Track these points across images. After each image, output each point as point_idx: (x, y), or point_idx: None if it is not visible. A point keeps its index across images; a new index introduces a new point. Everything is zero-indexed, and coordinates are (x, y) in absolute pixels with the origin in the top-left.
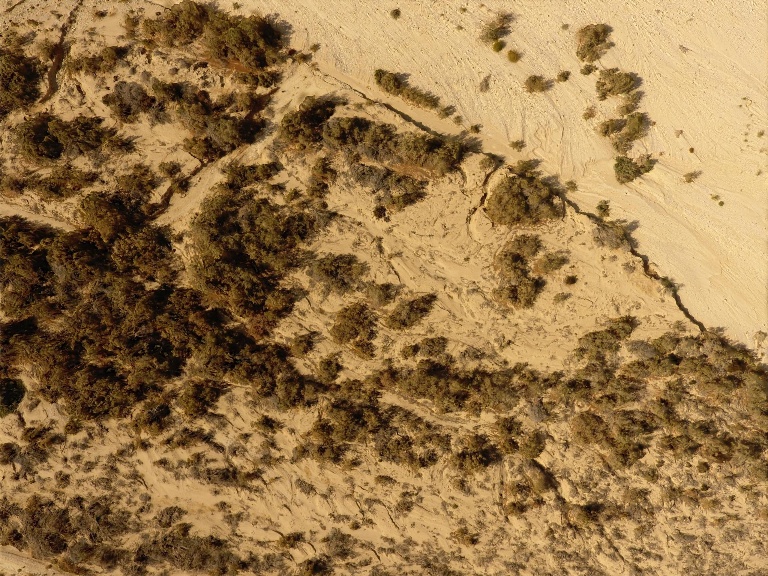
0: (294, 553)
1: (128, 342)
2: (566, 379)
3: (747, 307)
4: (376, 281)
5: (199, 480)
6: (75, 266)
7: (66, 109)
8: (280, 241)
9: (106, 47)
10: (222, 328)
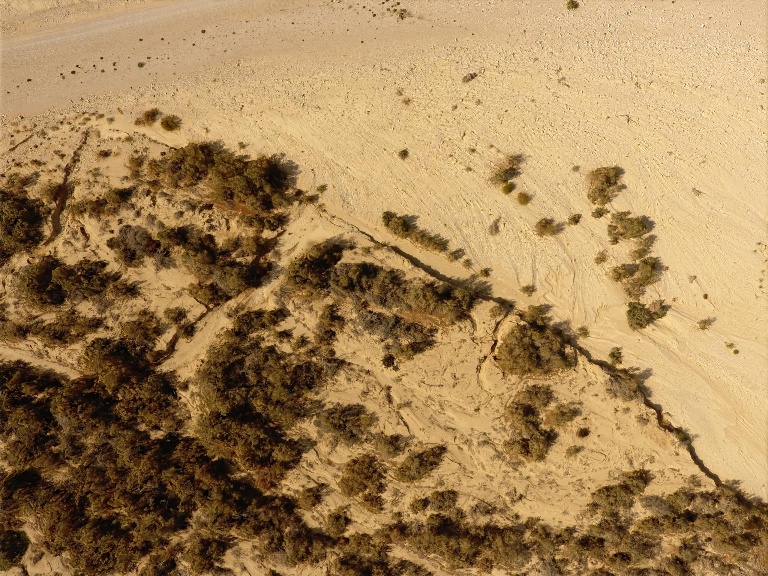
0: None
1: (133, 498)
2: (579, 535)
3: (763, 459)
4: (385, 432)
5: None
6: (79, 419)
7: (70, 252)
8: (287, 393)
9: (110, 189)
10: (229, 480)
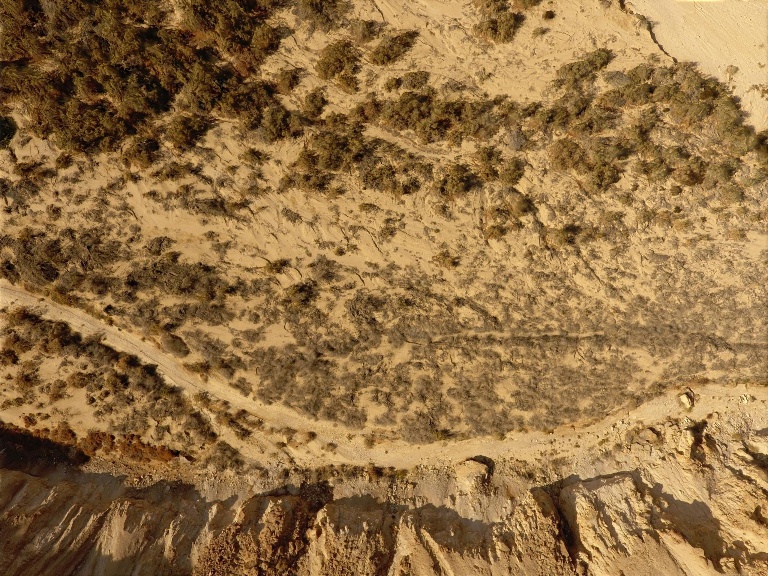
0: (281, 278)
1: (117, 72)
2: (544, 109)
3: (719, 43)
4: (360, 19)
5: (188, 210)
6: None
7: None
8: None
9: None
10: None
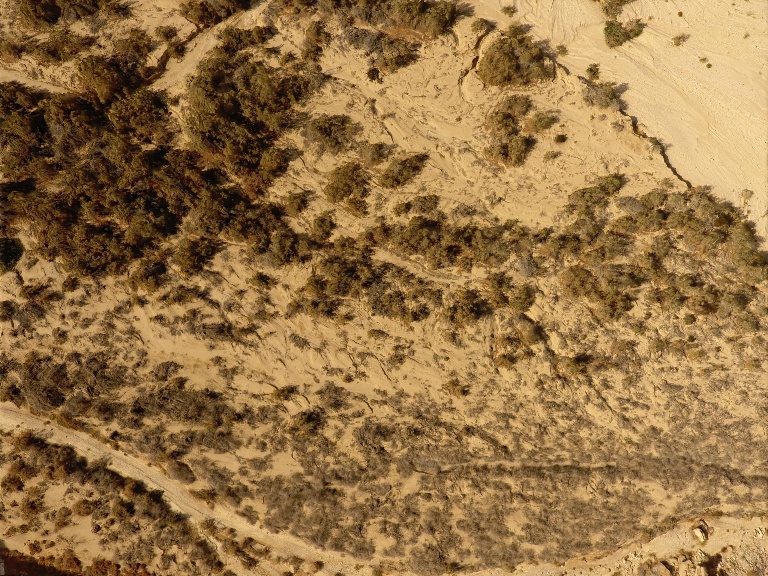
0: (288, 405)
1: (125, 198)
2: (556, 235)
3: (734, 166)
4: (369, 141)
5: (195, 335)
6: (72, 124)
7: None
8: (275, 100)
9: None
10: None
